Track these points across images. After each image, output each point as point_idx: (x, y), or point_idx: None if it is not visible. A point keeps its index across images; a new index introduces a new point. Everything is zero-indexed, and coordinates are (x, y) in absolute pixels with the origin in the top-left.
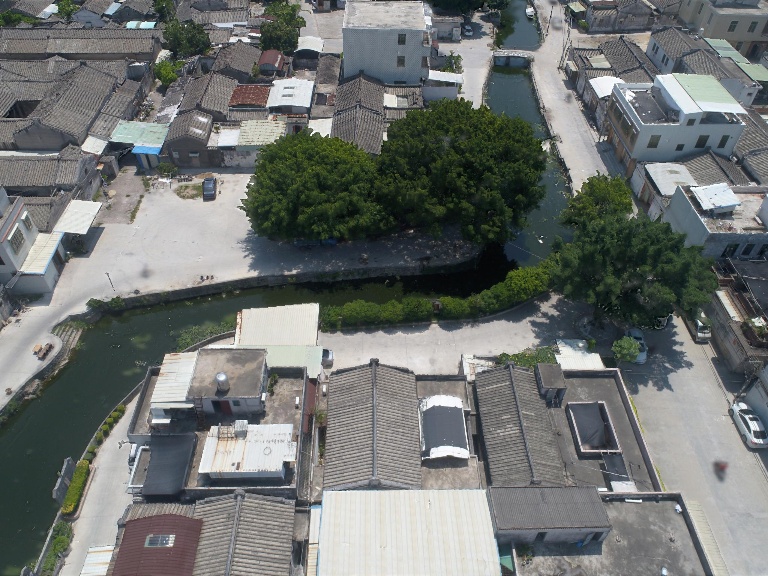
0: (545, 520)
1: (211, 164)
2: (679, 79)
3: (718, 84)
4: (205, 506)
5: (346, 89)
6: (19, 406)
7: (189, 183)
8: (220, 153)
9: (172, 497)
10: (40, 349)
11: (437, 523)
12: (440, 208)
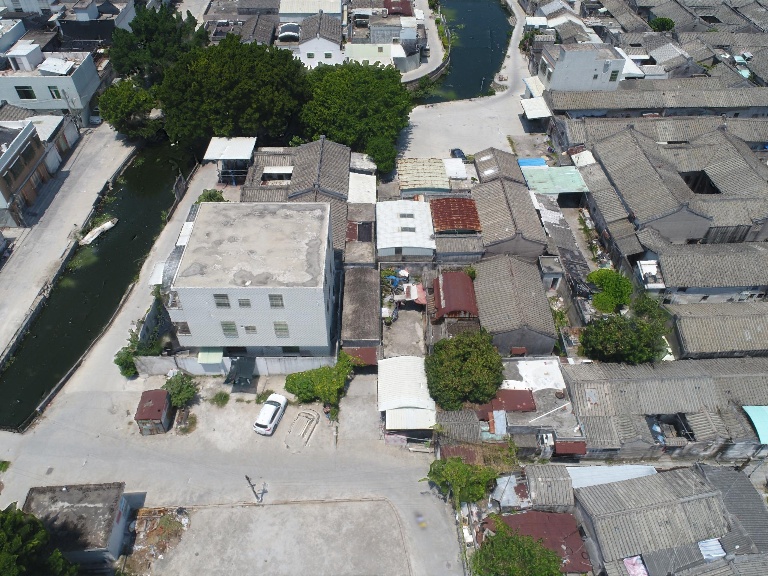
0: (261, 1)
1: None
2: None
3: None
4: None
5: None
6: None
7: None
8: None
9: None
10: None
11: (300, 5)
12: None
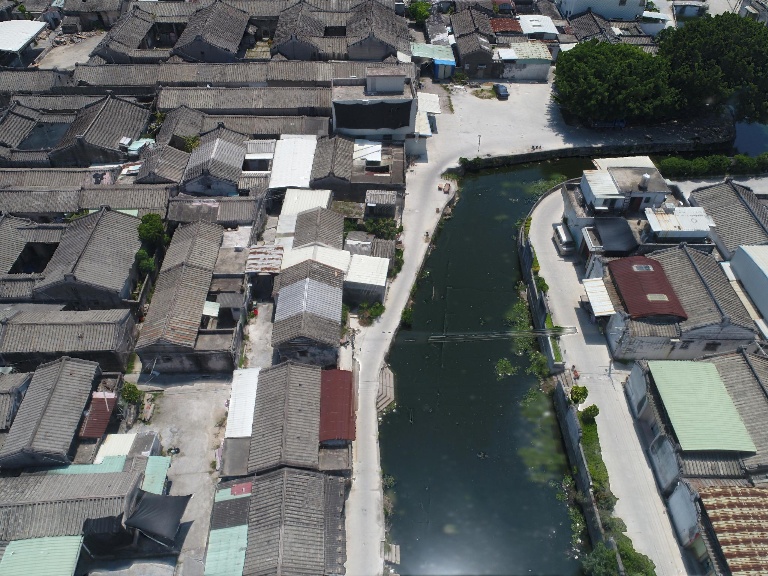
0: None
1: (492, 76)
2: None
3: None
4: (655, 256)
5: (580, 22)
6: (443, 222)
7: (480, 89)
8: (502, 66)
9: (625, 253)
10: (443, 187)
11: None
12: (731, 89)
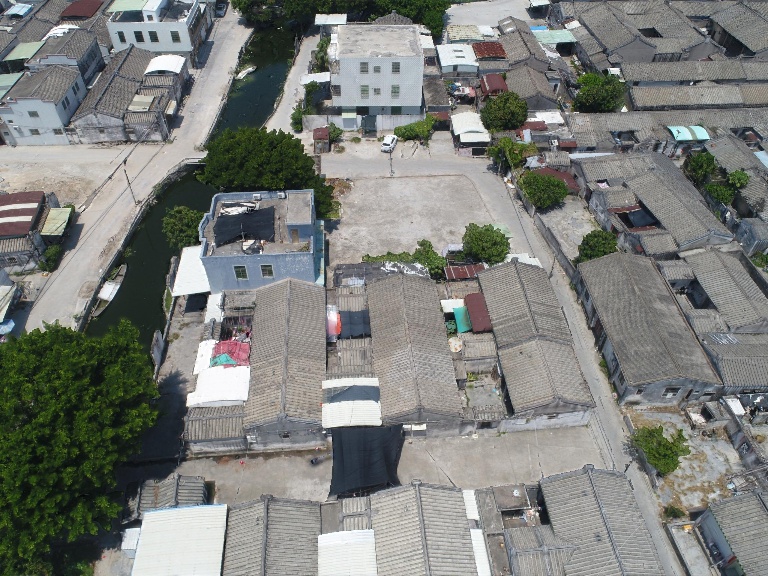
0: None
1: None
2: (143, 5)
3: (114, 5)
4: None
5: None
6: None
7: None
8: None
9: None
10: None
11: None
12: None
